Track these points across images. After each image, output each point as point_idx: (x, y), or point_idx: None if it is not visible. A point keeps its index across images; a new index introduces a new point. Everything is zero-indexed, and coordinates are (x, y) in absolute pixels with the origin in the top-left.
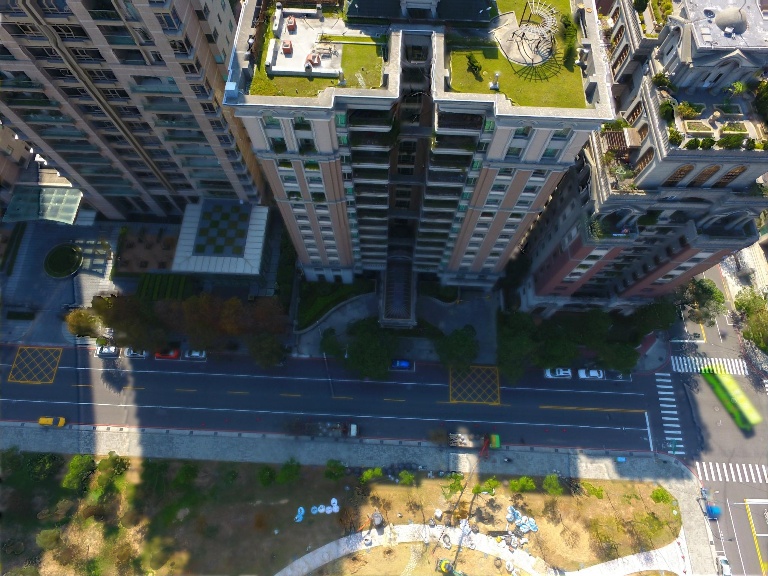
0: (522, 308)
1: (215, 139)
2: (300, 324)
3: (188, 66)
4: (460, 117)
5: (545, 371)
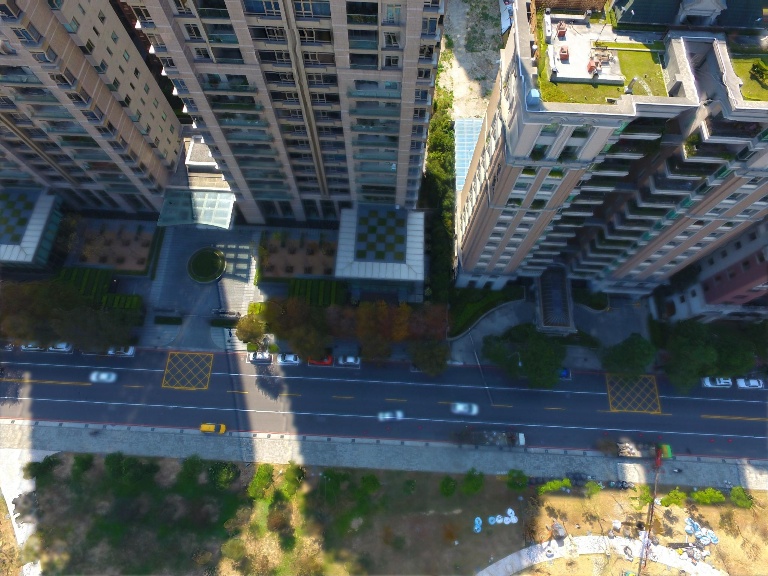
0: (679, 316)
1: (407, 144)
2: (452, 331)
3: (425, 71)
4: (730, 125)
5: (704, 380)
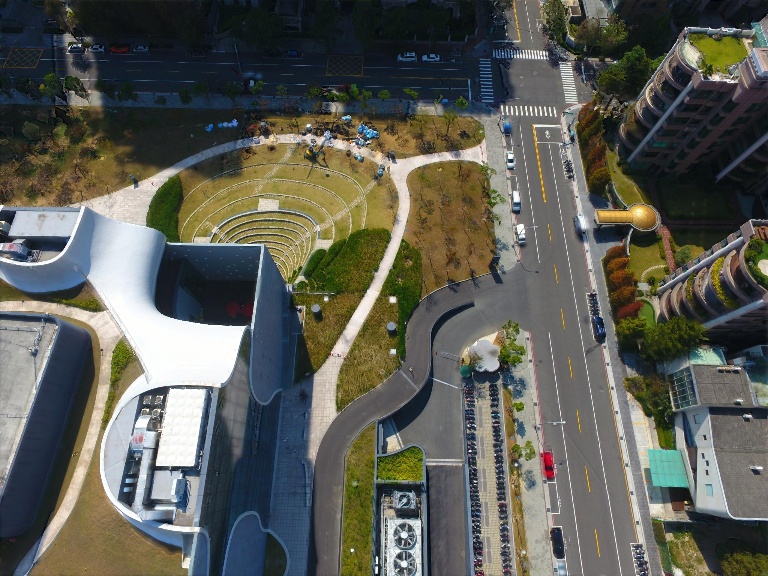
0: None
1: None
2: (219, 31)
3: None
4: None
5: (397, 56)
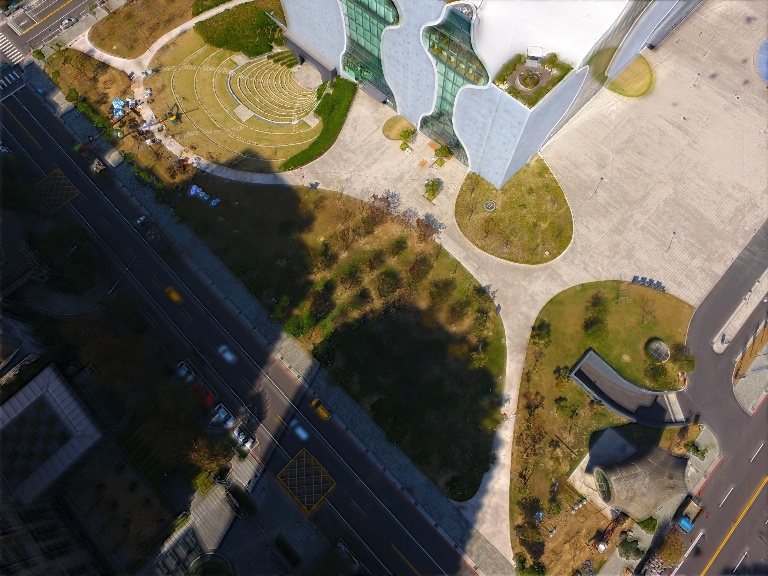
0: None
1: None
2: None
3: None
4: None
5: None
